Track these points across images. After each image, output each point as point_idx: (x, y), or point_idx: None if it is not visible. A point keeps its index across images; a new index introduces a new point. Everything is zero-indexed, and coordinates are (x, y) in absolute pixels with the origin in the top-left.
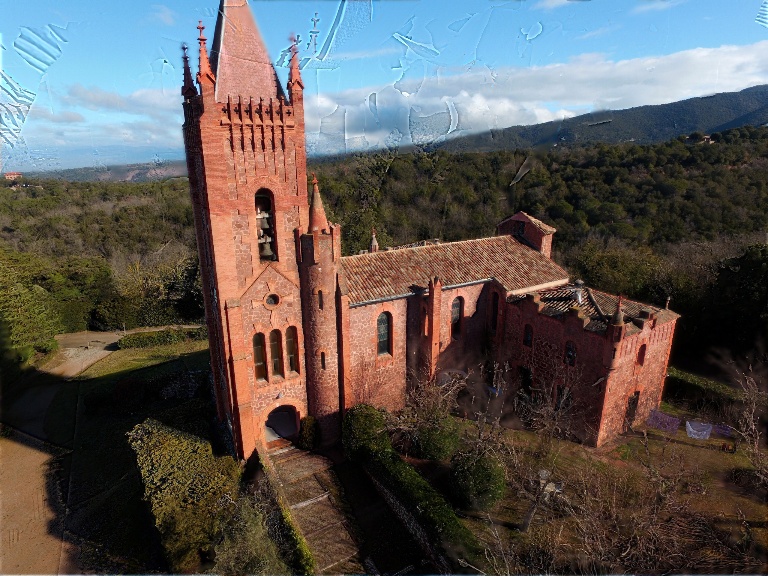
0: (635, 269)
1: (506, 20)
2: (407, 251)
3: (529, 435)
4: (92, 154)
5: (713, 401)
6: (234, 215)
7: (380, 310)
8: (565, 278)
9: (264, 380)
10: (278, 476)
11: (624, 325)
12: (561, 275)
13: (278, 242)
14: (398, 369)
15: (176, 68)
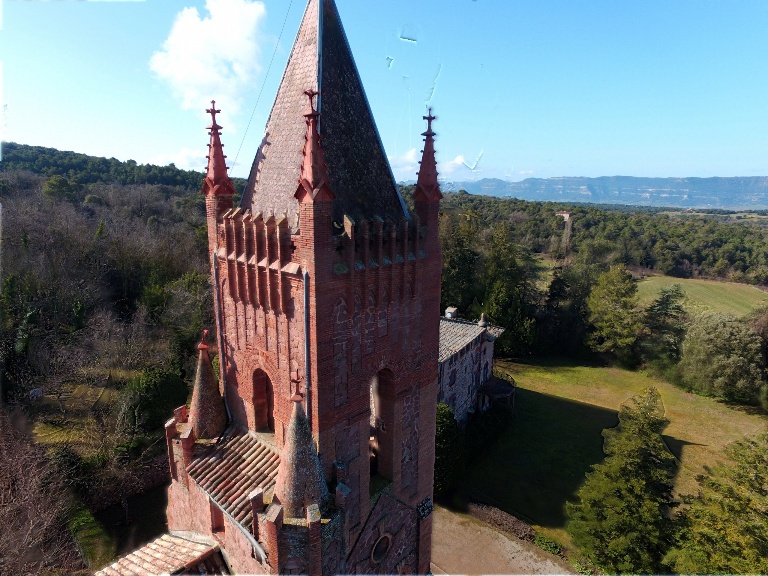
0: None
1: None
2: None
3: None
4: None
5: None
6: None
7: None
8: None
9: None
10: None
11: None
12: None
13: None
14: None
15: None
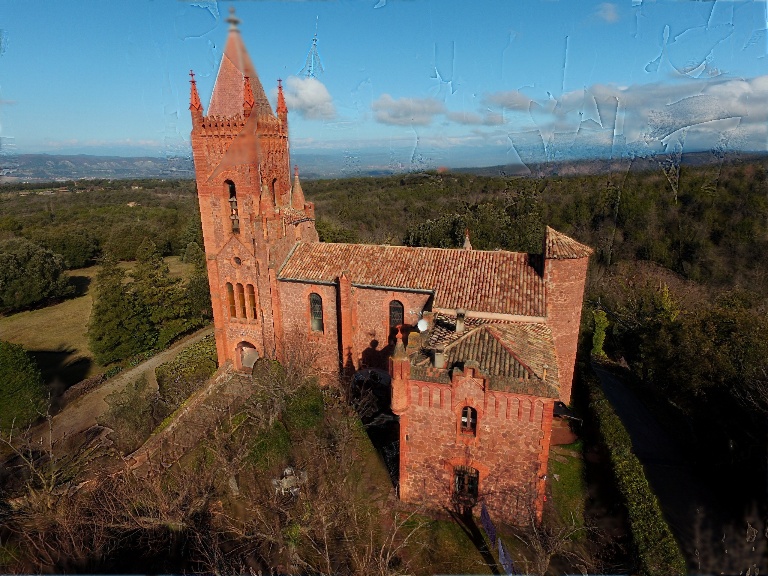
0: (766, 349)
1: (397, 12)
2: (378, 248)
3: (373, 455)
4: (389, 154)
5: (636, 567)
6: (212, 197)
7: (310, 290)
8: (537, 316)
9: (236, 318)
10: (222, 386)
11: (398, 361)
12: (534, 311)
13: (239, 220)
14: (331, 349)
15: (444, 79)
